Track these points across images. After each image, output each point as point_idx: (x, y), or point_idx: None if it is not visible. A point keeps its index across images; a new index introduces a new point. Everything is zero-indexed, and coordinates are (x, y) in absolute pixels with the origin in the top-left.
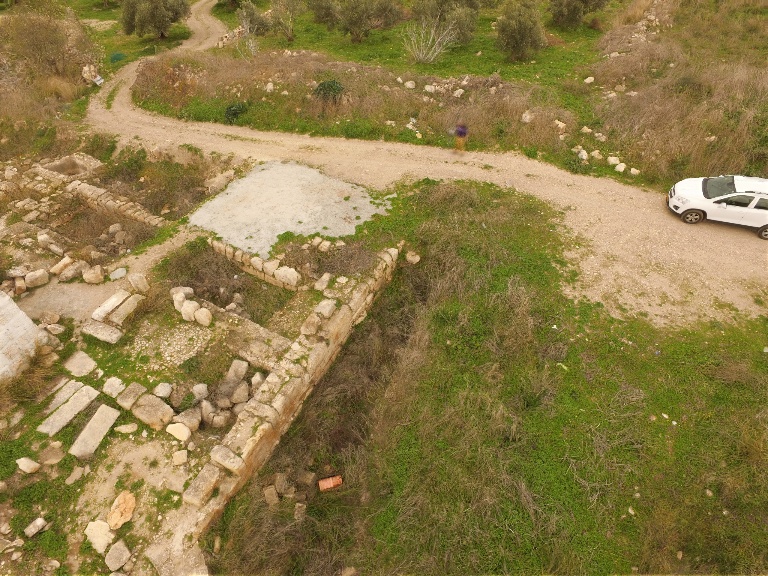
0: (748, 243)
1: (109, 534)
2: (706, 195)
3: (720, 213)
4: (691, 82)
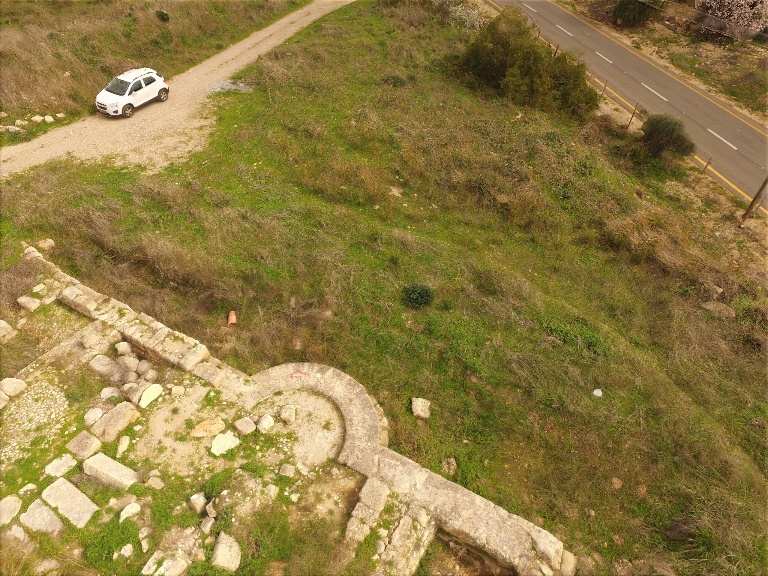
0: (163, 106)
1: (226, 434)
2: (120, 95)
3: (137, 99)
4: None
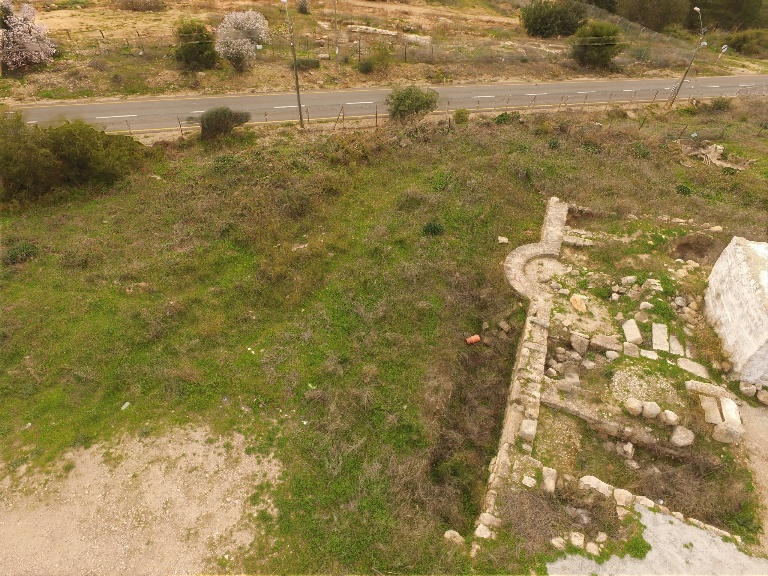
0: None
1: None
2: None
3: None
4: None
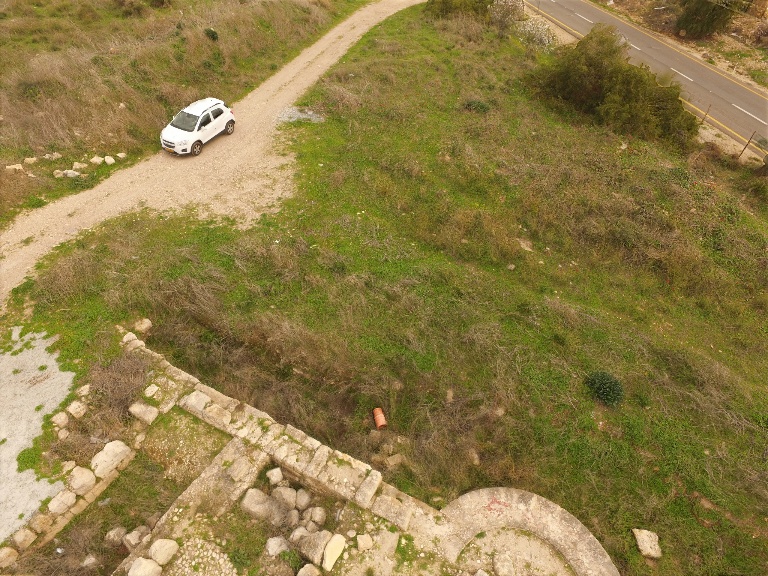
0: (231, 141)
1: None
2: (188, 131)
3: (205, 135)
4: (34, 83)
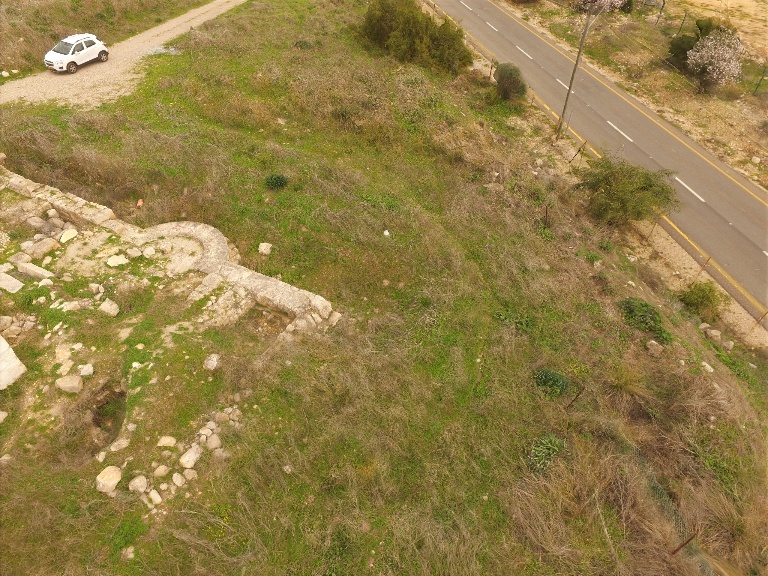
0: (103, 65)
1: (119, 256)
2: (64, 54)
3: (79, 59)
4: None
